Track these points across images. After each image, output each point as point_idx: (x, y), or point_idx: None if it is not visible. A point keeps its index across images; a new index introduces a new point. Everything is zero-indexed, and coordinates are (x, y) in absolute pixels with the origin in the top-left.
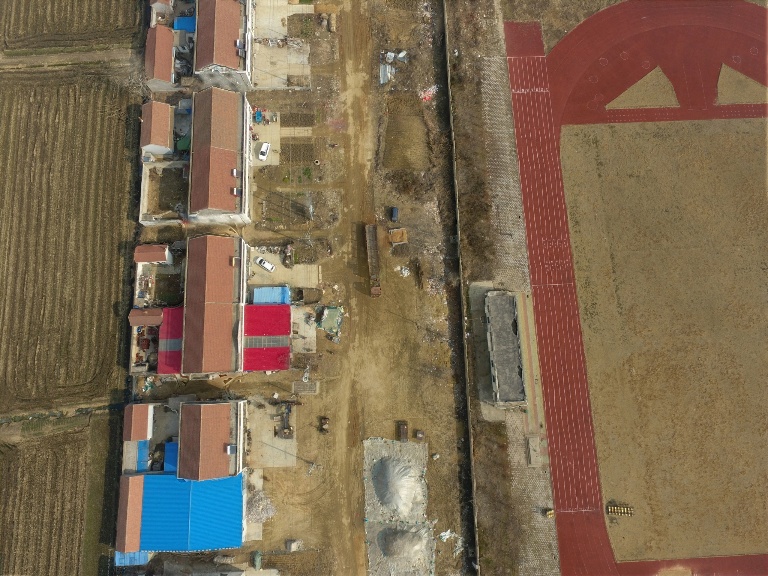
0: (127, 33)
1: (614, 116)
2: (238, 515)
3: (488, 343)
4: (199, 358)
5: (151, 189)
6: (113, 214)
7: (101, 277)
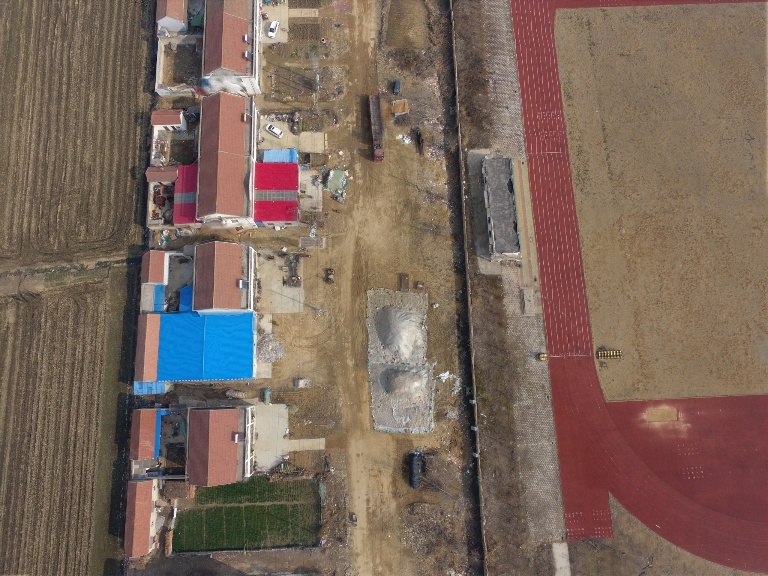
0: None
1: (606, 1)
2: (249, 350)
3: (485, 201)
4: (213, 201)
5: (166, 64)
6: (130, 87)
7: (119, 144)
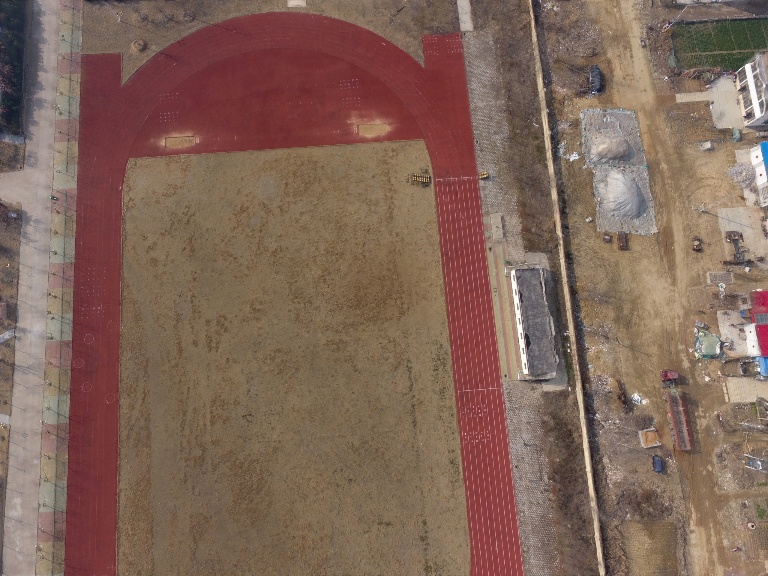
0: None
1: None
2: None
3: None
4: None
5: None
6: None
7: None
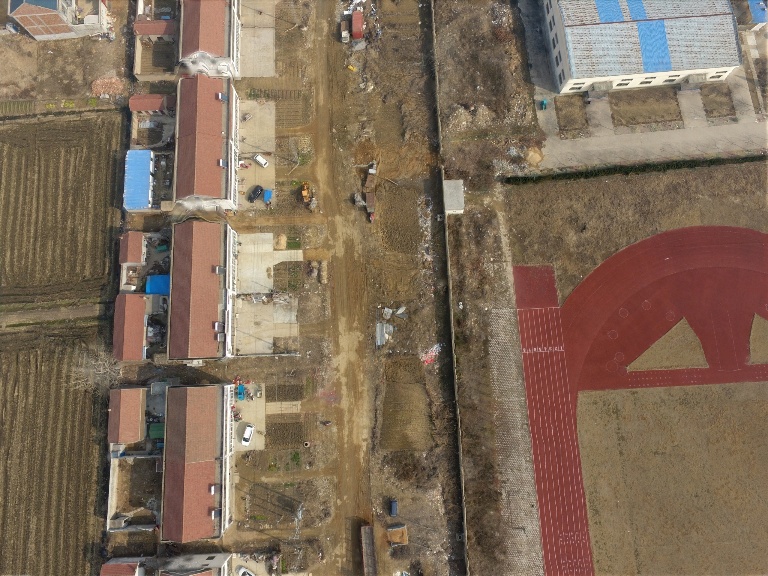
0: (95, 285)
1: (636, 380)
2: None
3: None
4: None
5: (121, 481)
6: (78, 509)
7: None
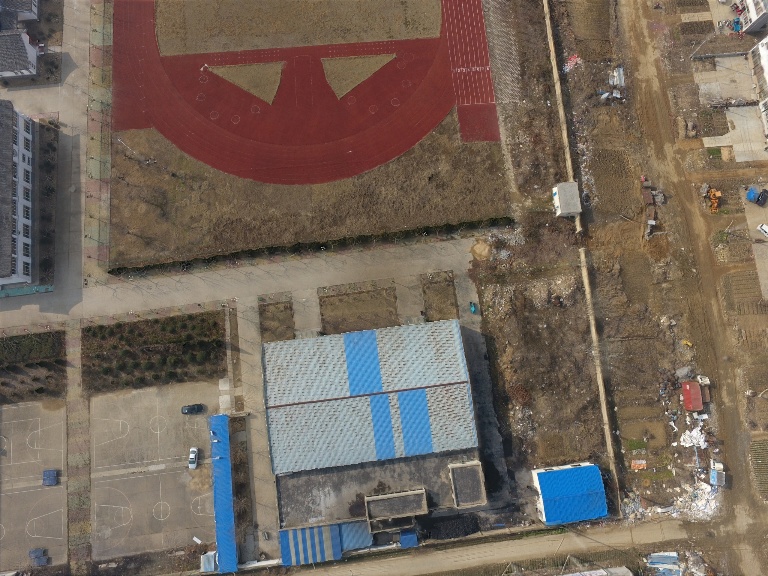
0: None
1: (388, 47)
2: None
3: None
4: None
5: None
6: None
7: None
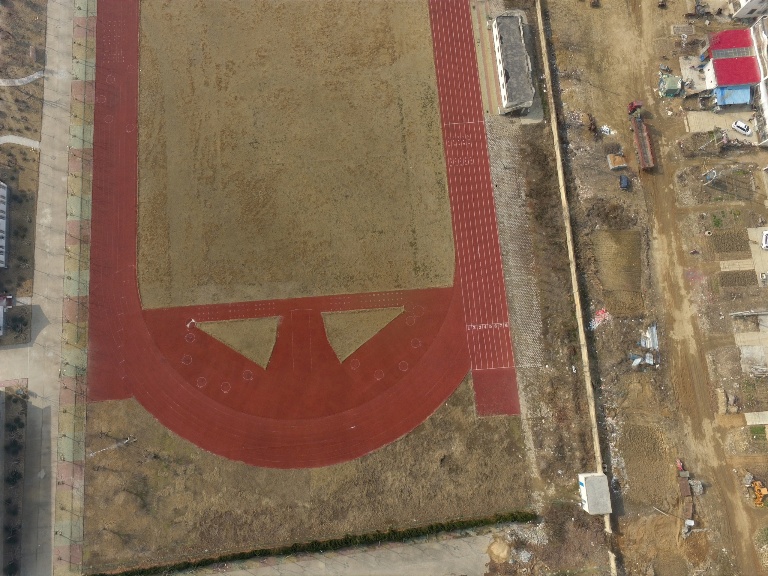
0: None
1: (395, 299)
2: None
3: None
4: None
5: None
6: None
7: None
